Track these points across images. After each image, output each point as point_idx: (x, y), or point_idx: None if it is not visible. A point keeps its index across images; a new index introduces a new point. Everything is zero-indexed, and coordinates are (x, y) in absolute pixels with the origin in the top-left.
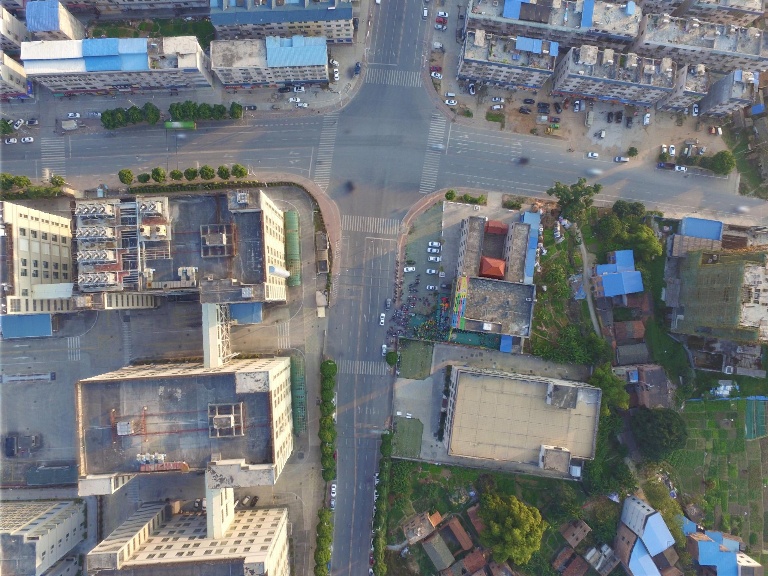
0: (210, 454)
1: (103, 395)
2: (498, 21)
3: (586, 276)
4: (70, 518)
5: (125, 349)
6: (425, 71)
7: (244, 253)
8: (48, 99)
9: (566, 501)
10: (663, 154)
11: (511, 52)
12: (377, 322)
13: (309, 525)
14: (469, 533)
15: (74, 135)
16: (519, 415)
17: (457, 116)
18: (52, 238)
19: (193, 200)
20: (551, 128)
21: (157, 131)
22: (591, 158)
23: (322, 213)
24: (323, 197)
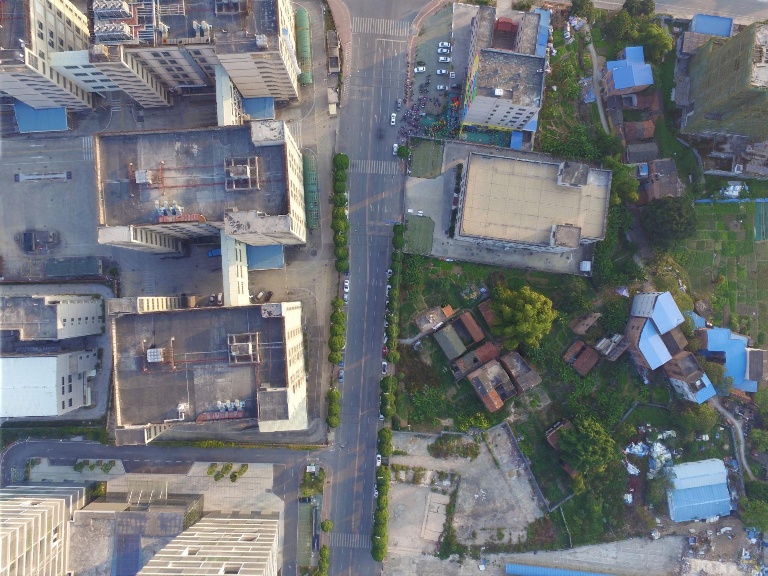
0: None
1: (121, 150)
2: None
3: (596, 79)
4: (89, 304)
5: None
6: None
7: (257, 12)
8: None
9: (576, 292)
10: None
11: None
12: (388, 122)
13: (323, 320)
14: (480, 328)
15: None
16: (530, 196)
17: None
18: (66, 21)
19: None
20: None
21: None
22: None
23: (332, 13)
24: None
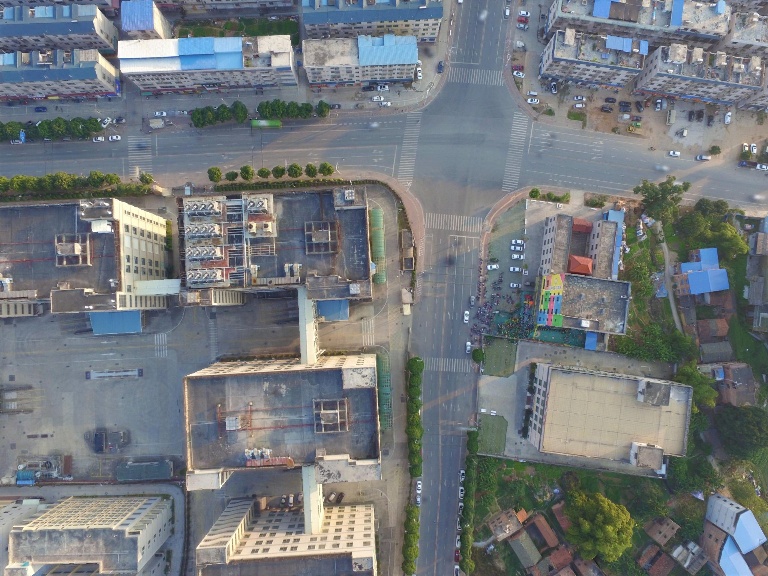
0: (314, 449)
1: (209, 390)
2: (586, 20)
3: (668, 274)
4: (161, 513)
5: (211, 346)
6: (507, 70)
7: (347, 250)
8: (135, 98)
9: (652, 499)
10: (746, 152)
11: (600, 51)
12: (461, 319)
13: (394, 522)
14: (554, 530)
15: (160, 133)
16: (610, 412)
17: (539, 115)
18: (147, 235)
19: (296, 197)
20: (633, 127)
21: (242, 129)
22: (672, 156)
23: (406, 211)
24: (407, 195)
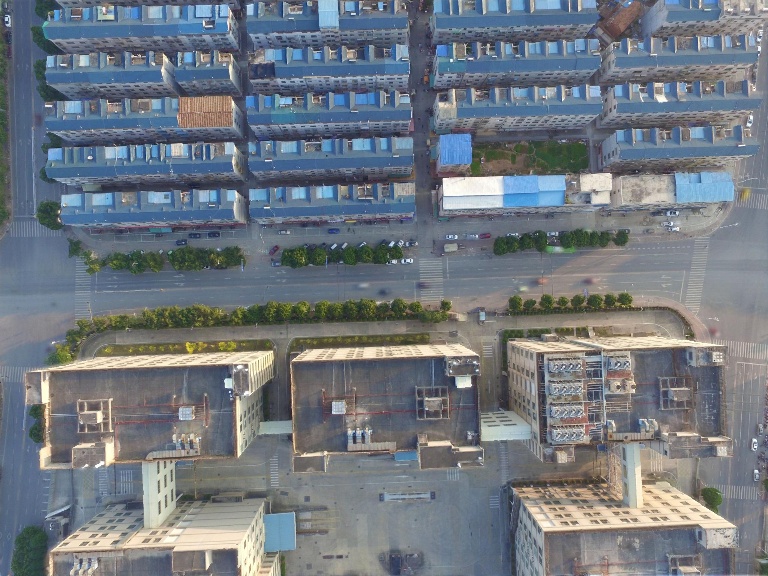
0: None
1: (564, 544)
2: None
3: None
4: None
5: (502, 470)
6: None
7: (698, 405)
8: (425, 220)
9: None
10: None
11: None
12: (748, 447)
13: None
14: None
15: (451, 256)
16: None
17: None
18: None
19: (648, 351)
20: None
21: (532, 253)
22: None
23: (696, 338)
24: (694, 321)
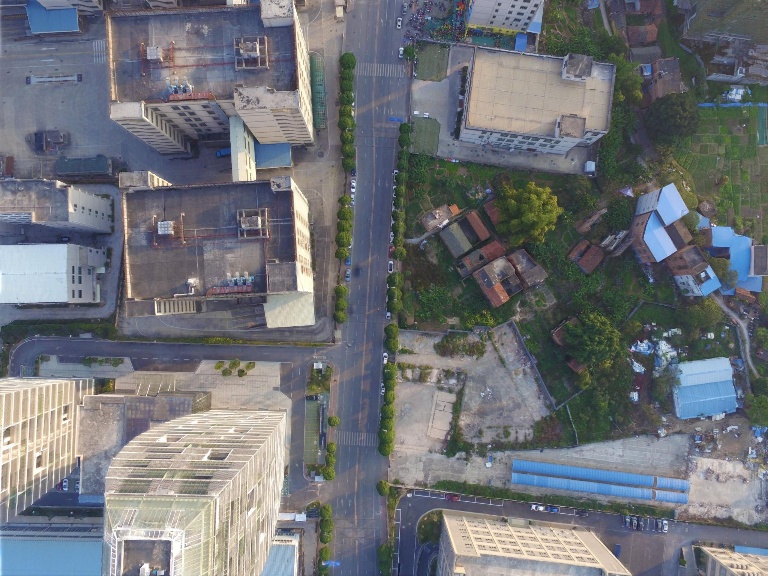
0: None
1: (132, 30)
2: None
3: None
4: (99, 199)
5: None
6: None
7: None
8: None
9: (581, 190)
10: None
11: None
12: (394, 26)
13: (329, 221)
14: (486, 228)
15: None
16: (535, 90)
17: None
18: None
19: None
20: None
21: None
22: None
23: None
24: None
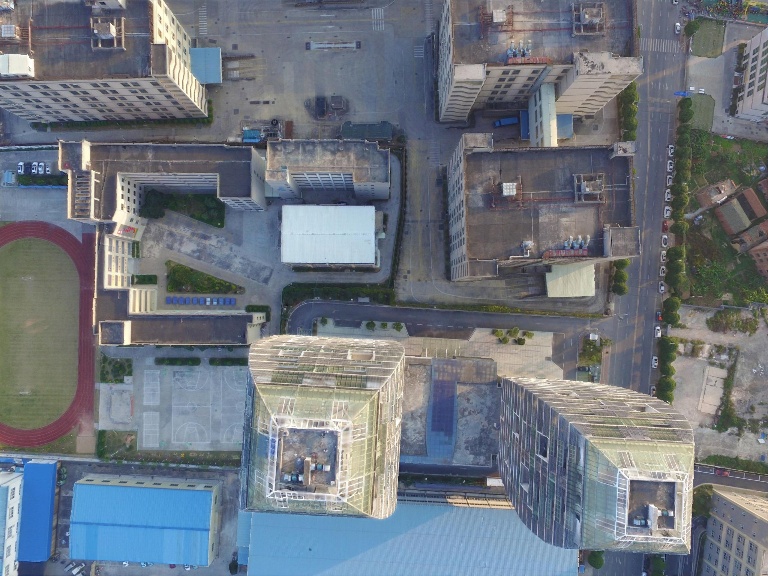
0: (572, 53)
1: None
2: None
3: None
4: None
5: (427, 21)
6: None
7: None
8: None
9: None
10: None
11: None
12: (670, 2)
13: None
14: None
15: None
16: None
17: None
18: None
19: None
20: None
21: None
22: None
23: None
24: None
